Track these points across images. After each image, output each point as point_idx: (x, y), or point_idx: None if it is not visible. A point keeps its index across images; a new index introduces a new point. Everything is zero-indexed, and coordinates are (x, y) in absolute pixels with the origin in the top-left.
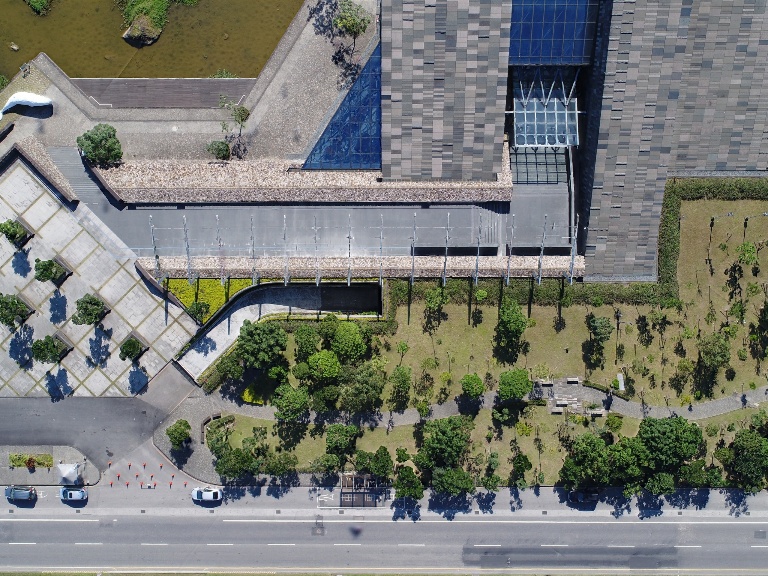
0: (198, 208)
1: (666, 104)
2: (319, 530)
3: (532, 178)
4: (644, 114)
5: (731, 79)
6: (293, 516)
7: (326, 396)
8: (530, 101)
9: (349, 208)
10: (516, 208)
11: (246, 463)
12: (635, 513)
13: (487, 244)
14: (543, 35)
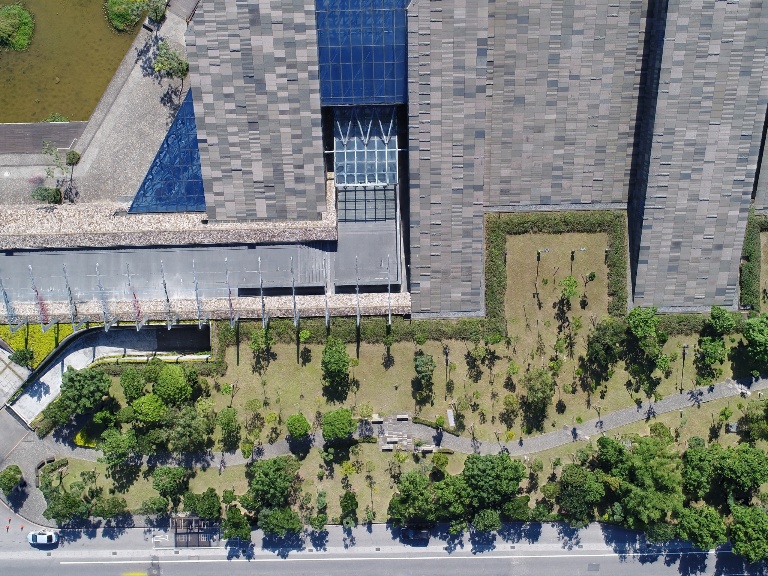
0: (26, 254)
1: (473, 143)
2: (155, 570)
3: (360, 215)
4: (452, 153)
5: (545, 114)
6: (129, 557)
7: (151, 440)
8: (351, 140)
9: (176, 250)
10: (344, 246)
11: (74, 507)
12: (468, 548)
13: (312, 284)
14: (353, 76)
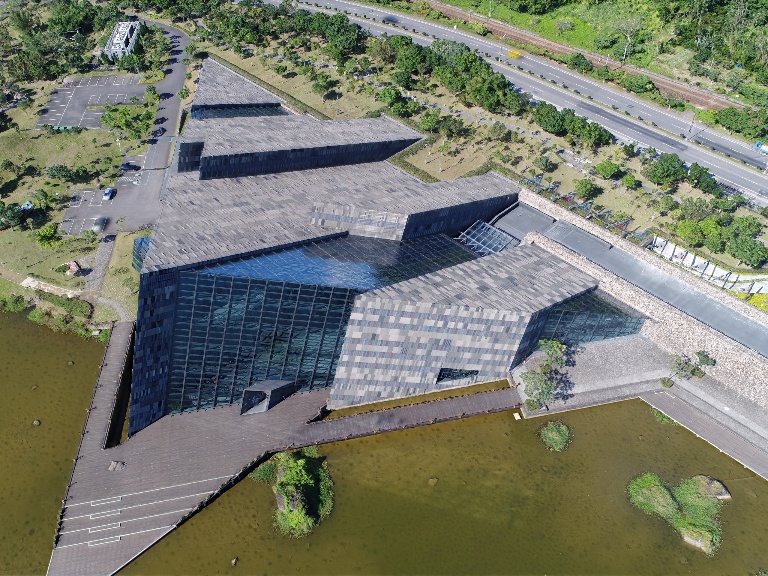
0: None
1: (432, 187)
2: (764, 192)
3: None
4: None
5: None
6: None
7: None
8: None
9: None
10: None
11: None
12: None
13: (567, 223)
14: None
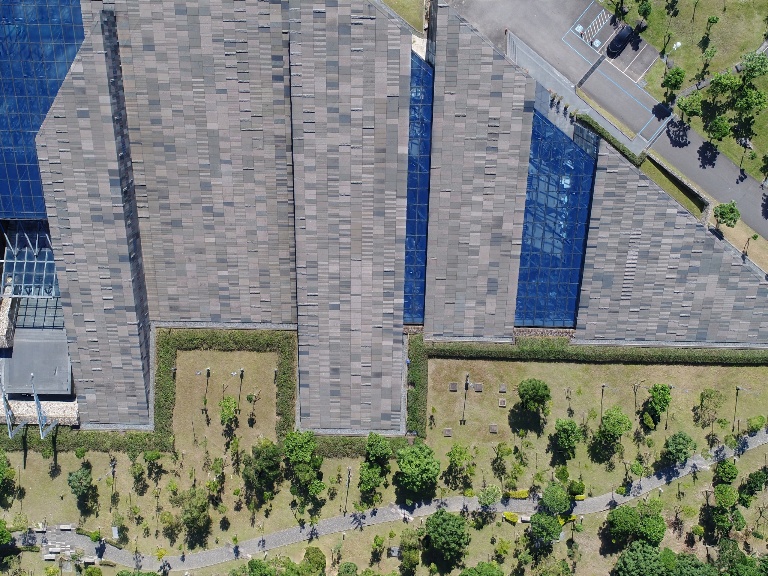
0: None
1: (119, 267)
2: None
3: (39, 322)
4: (100, 275)
5: (205, 237)
6: None
7: None
8: (22, 250)
9: None
10: (19, 353)
11: None
12: None
13: None
14: (12, 191)
